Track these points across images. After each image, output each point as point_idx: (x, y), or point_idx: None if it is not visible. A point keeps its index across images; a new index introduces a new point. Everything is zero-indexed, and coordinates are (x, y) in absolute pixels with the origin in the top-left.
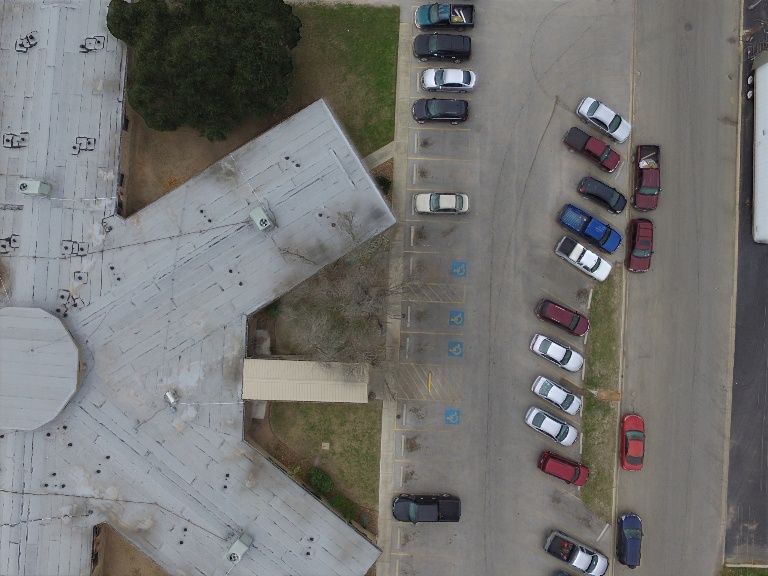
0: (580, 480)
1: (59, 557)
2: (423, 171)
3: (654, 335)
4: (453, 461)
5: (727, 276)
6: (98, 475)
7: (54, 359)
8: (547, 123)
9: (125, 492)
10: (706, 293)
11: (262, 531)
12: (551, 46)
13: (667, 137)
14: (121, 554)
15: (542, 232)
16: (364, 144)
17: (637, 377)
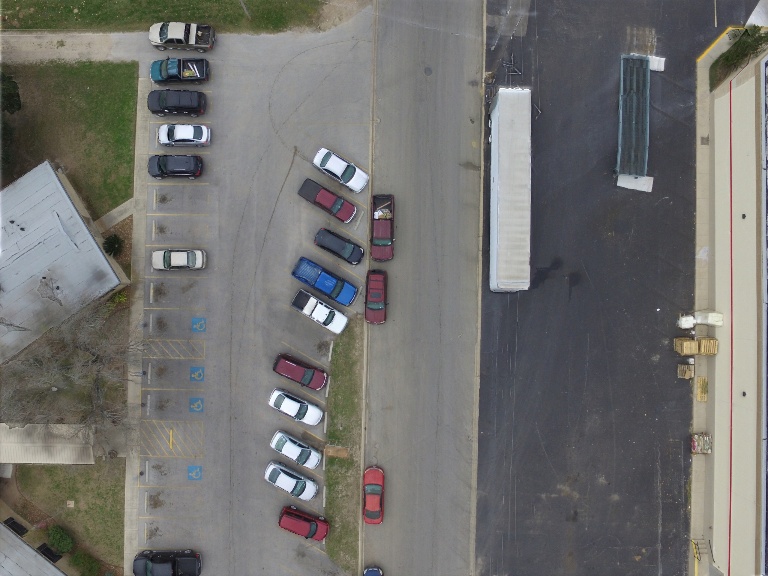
0: (318, 535)
1: None
2: (162, 227)
3: (396, 386)
4: (196, 517)
5: (470, 324)
6: None
7: None
8: (286, 174)
9: None
10: (449, 342)
11: None
12: (289, 96)
13: (407, 185)
14: None
15: (281, 285)
16: (103, 202)
17: (380, 429)
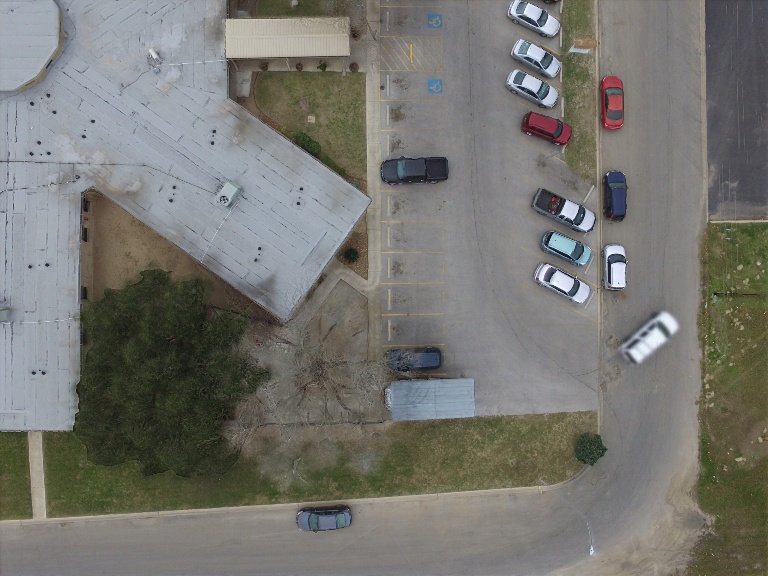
0: (563, 135)
1: (47, 226)
2: None
3: (627, 2)
4: (438, 129)
5: None
6: (84, 141)
7: (35, 18)
8: None
9: (112, 156)
10: None
11: (251, 184)
12: None
13: None
14: (111, 239)
15: None
16: None
17: (613, 43)
